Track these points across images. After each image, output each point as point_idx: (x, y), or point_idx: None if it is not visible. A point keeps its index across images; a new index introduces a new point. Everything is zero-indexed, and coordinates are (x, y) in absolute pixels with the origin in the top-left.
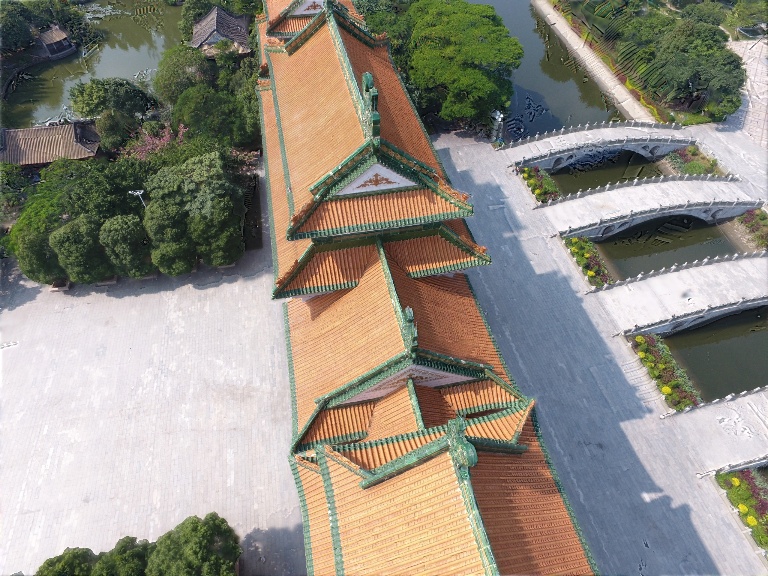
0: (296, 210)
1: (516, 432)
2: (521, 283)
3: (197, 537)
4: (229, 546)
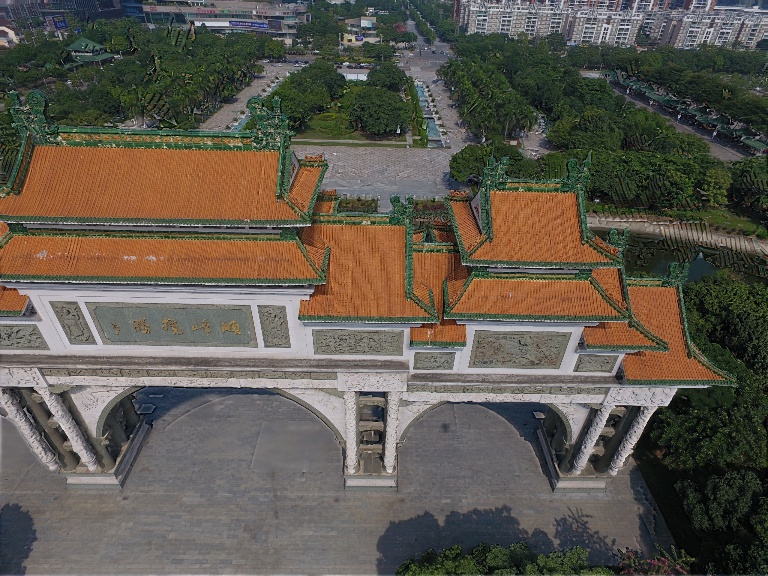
0: (277, 219)
1: None
2: None
3: (421, 572)
4: (427, 557)
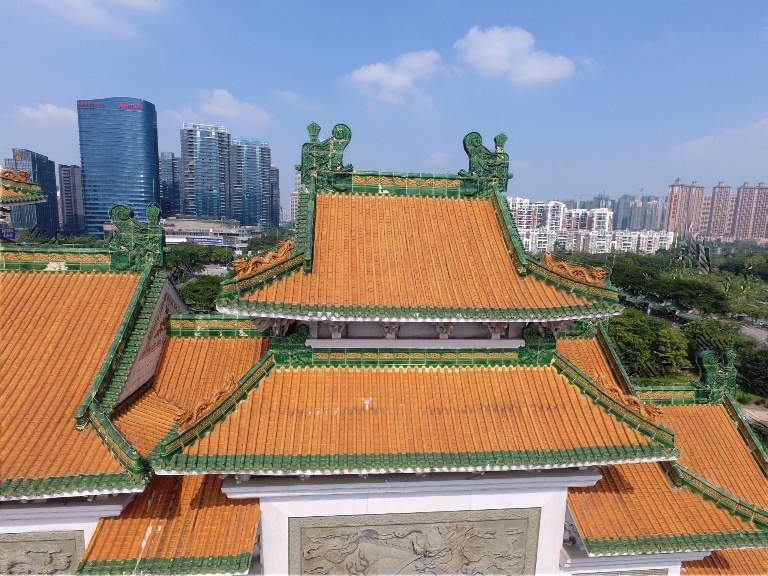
0: None
1: None
2: None
3: None
4: None
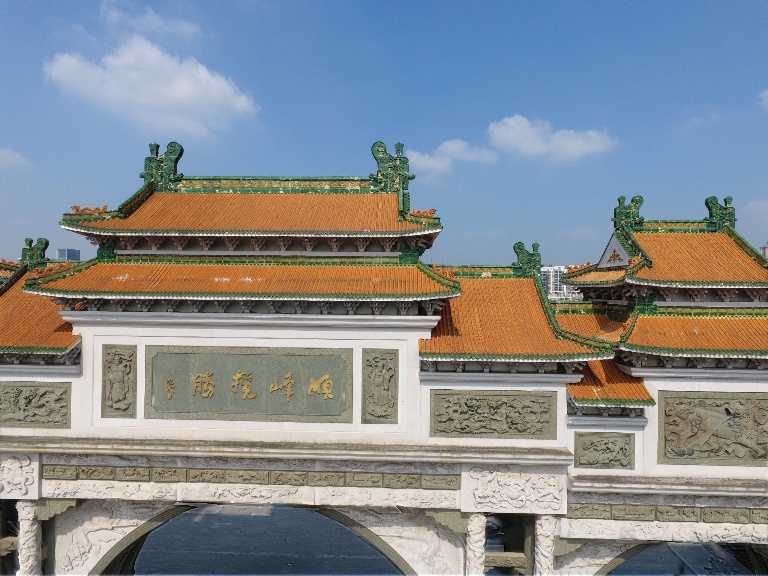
0: (401, 230)
1: (591, 266)
2: (271, 528)
3: None
4: None
